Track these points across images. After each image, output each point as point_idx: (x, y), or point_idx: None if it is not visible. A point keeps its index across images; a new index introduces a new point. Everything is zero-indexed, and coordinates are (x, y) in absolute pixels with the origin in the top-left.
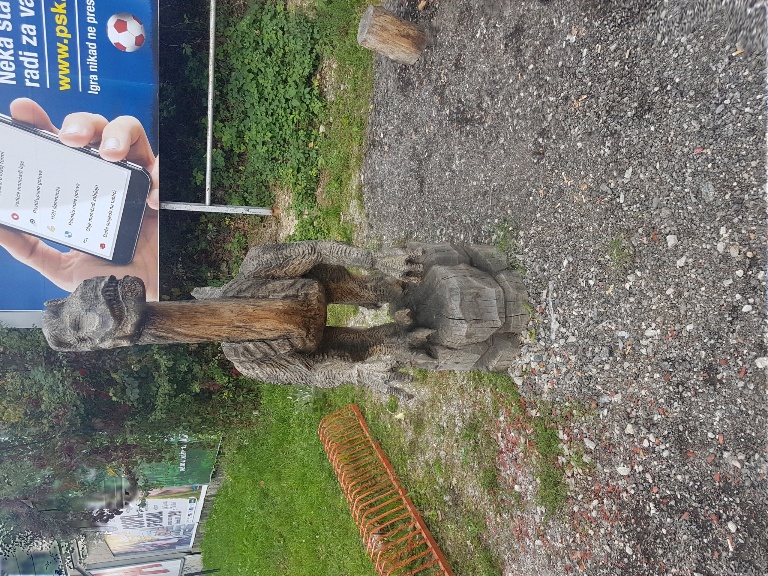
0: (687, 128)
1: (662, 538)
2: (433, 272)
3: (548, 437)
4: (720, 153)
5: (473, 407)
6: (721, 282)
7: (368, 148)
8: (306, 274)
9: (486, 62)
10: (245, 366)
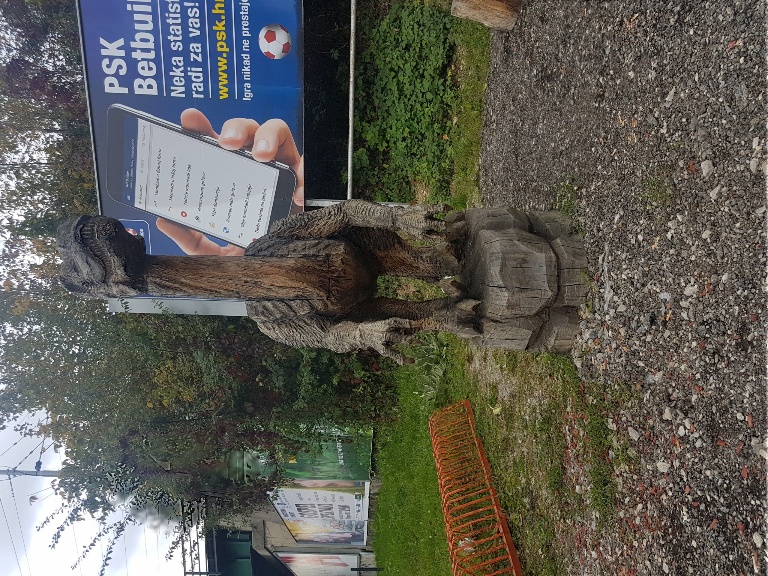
0: (722, 20)
1: (692, 552)
2: (479, 237)
3: (598, 427)
4: (752, 41)
5: (549, 397)
6: (755, 212)
7: (483, 129)
8: (335, 236)
9: (562, 6)
10: (267, 326)
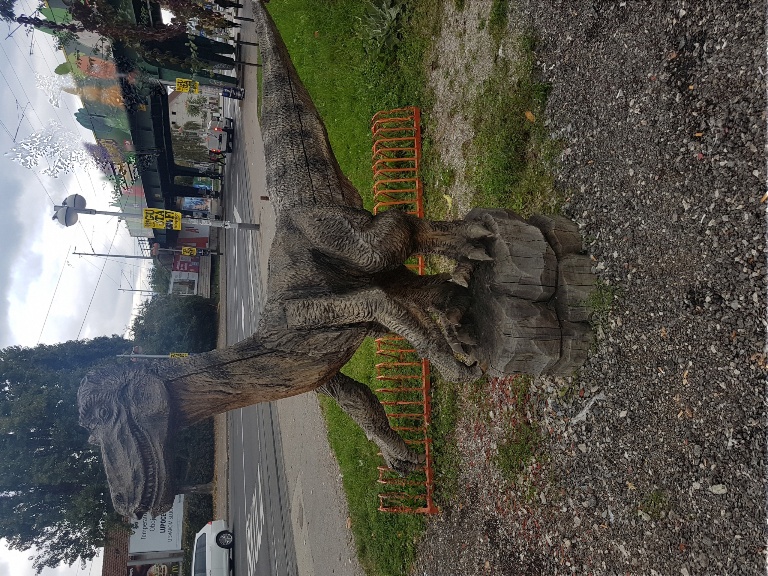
0: None
1: None
2: (501, 313)
3: None
4: None
5: None
6: None
7: None
8: None
9: None
10: None
